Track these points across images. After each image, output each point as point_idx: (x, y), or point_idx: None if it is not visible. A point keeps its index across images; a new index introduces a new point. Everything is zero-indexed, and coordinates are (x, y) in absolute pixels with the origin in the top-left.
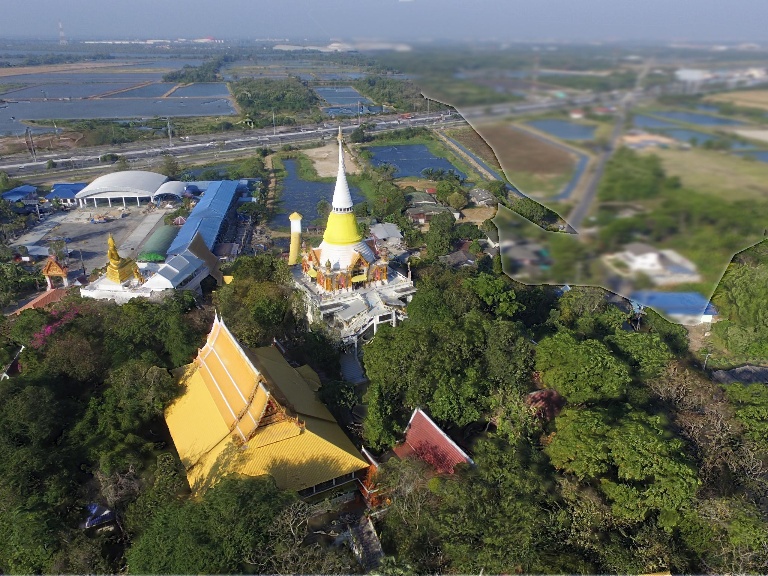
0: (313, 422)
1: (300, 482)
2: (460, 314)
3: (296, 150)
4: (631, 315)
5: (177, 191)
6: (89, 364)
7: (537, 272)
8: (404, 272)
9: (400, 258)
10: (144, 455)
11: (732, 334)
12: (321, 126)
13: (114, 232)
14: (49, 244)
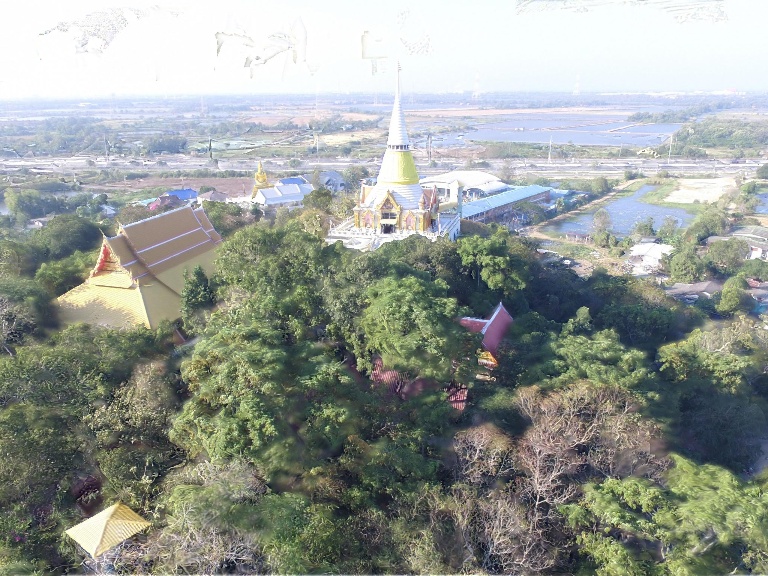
0: (164, 291)
1: (96, 321)
2: (412, 262)
3: (673, 178)
4: (749, 364)
5: (488, 188)
6: None
7: None
8: None
9: None
10: (76, 279)
11: None
12: (741, 162)
13: None
14: None
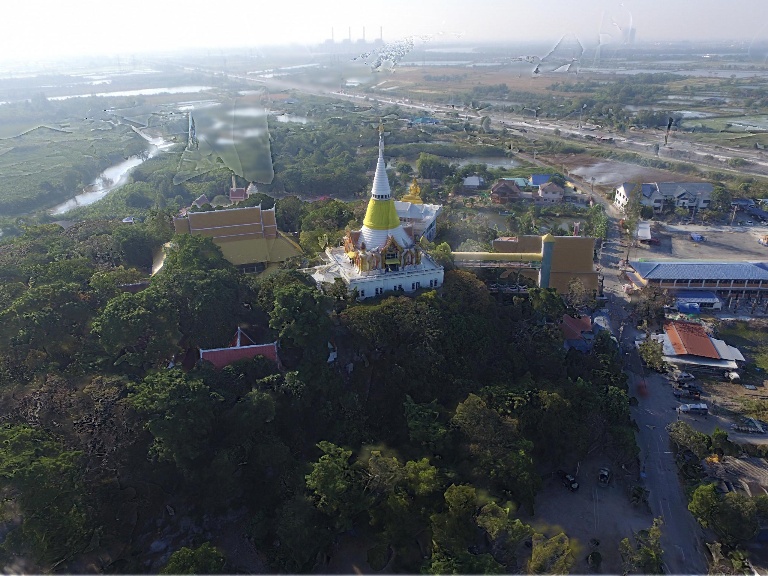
0: None
1: None
2: None
3: None
4: (310, 484)
5: None
6: (280, 208)
7: (4, 136)
8: None
9: None
10: None
11: None
12: None
13: (739, 253)
14: (682, 235)
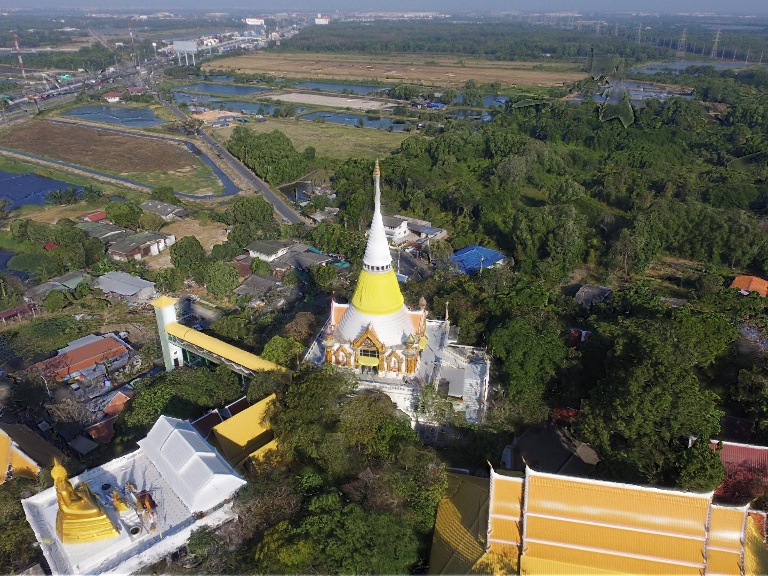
0: None
1: None
2: None
3: None
4: None
5: None
6: None
7: None
8: None
9: (184, 309)
10: None
11: (545, 268)
12: None
13: None
14: None
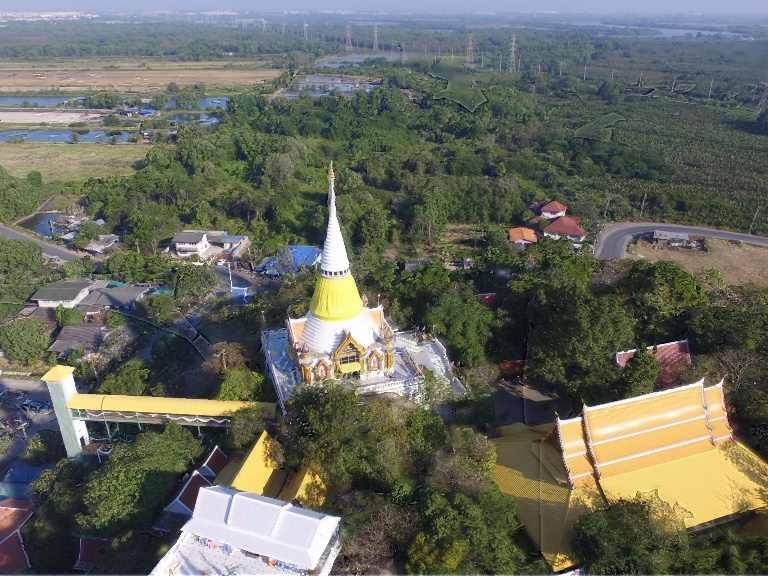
0: None
1: None
2: None
3: None
4: None
5: None
6: None
7: None
8: None
9: None
10: None
11: (367, 253)
12: None
13: None
14: None
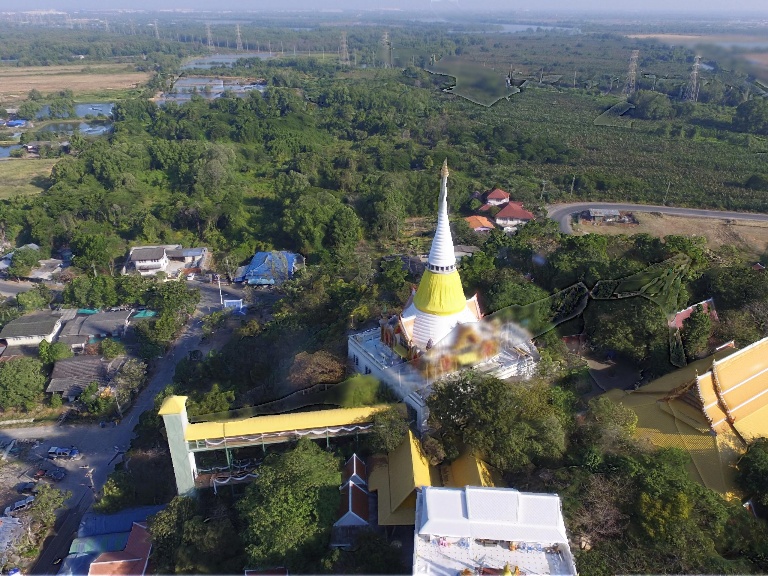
0: None
1: None
2: None
3: None
4: None
5: None
6: None
7: None
8: (377, 326)
9: None
10: None
11: None
12: None
13: None
14: None
